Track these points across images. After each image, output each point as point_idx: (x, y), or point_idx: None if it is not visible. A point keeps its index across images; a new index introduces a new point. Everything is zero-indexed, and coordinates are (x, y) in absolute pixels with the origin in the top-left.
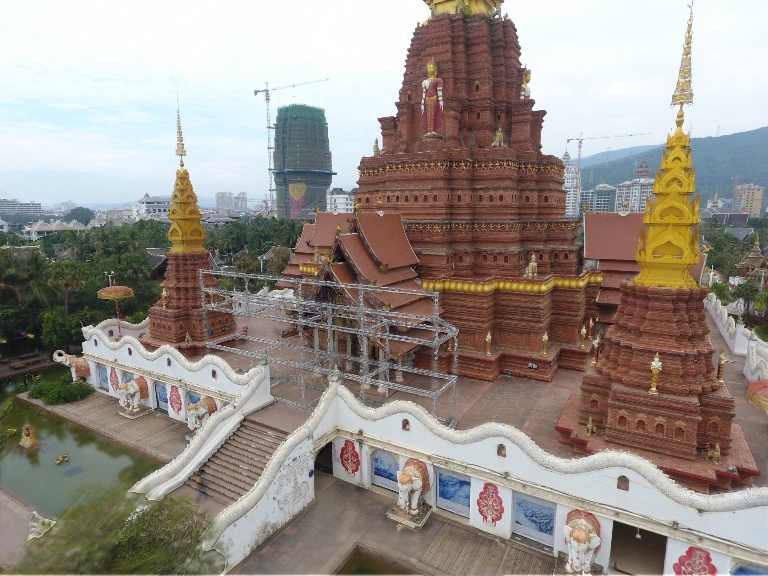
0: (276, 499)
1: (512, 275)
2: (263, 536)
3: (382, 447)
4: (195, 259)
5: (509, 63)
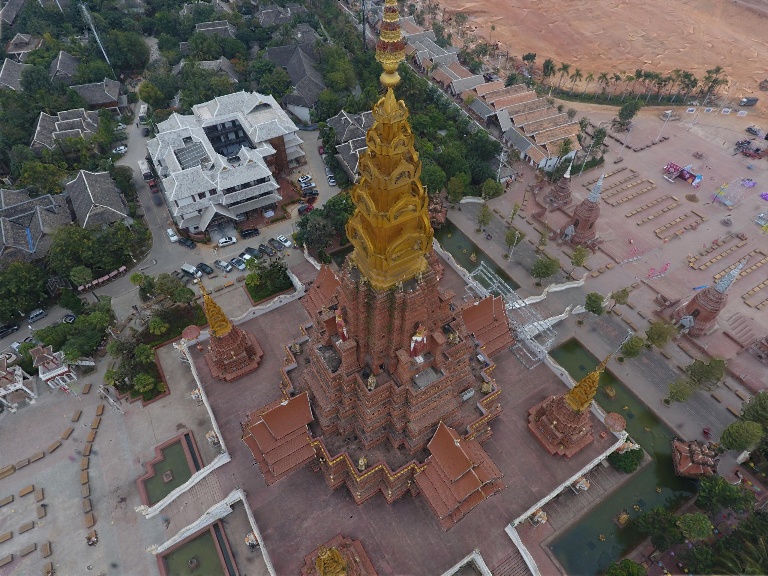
0: None
1: None
2: None
3: None
4: None
5: None
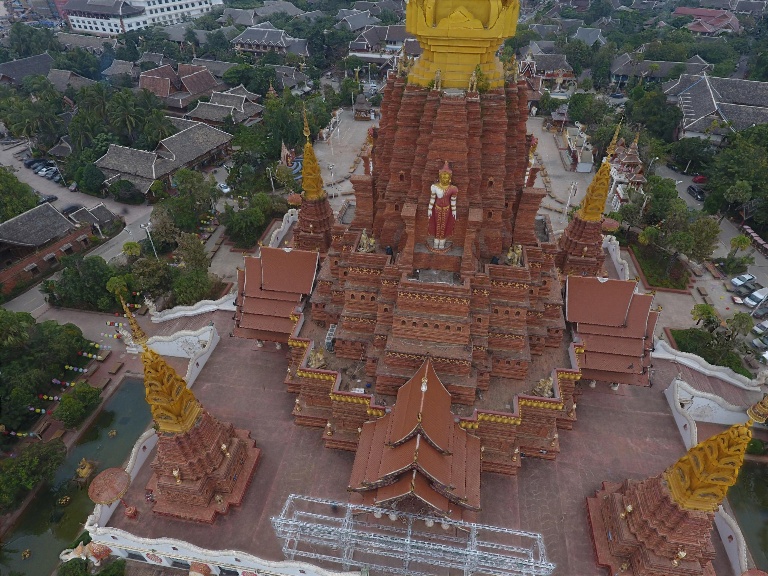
0: None
1: (523, 375)
2: None
3: None
4: (197, 429)
5: (520, 138)
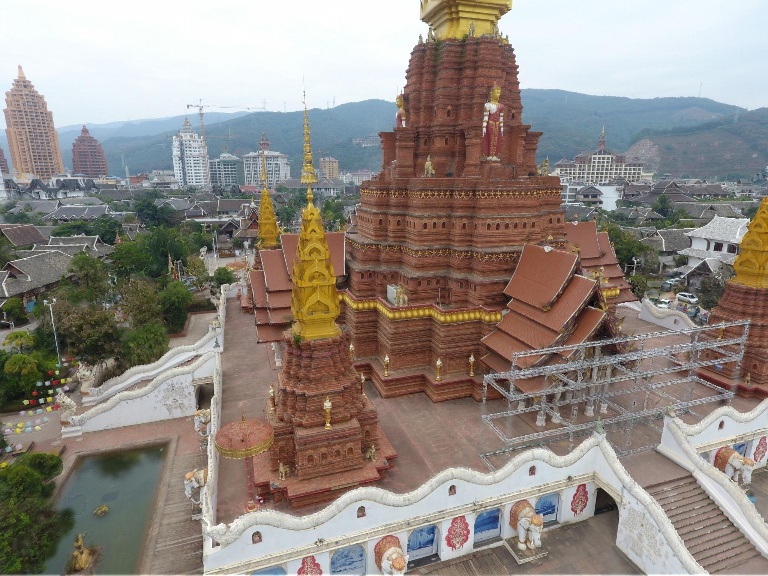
0: None
1: None
2: None
3: (703, 451)
4: None
5: None
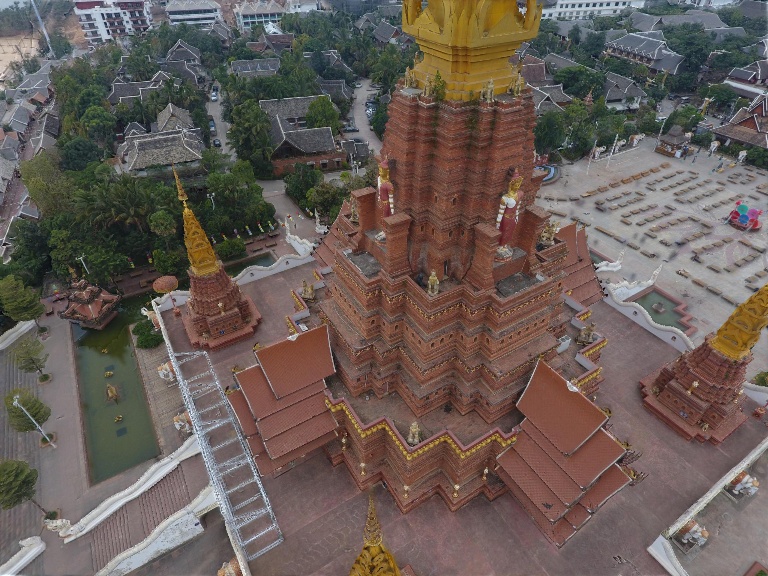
0: (164, 541)
1: None
2: (157, 555)
3: None
4: (206, 280)
5: (490, 167)
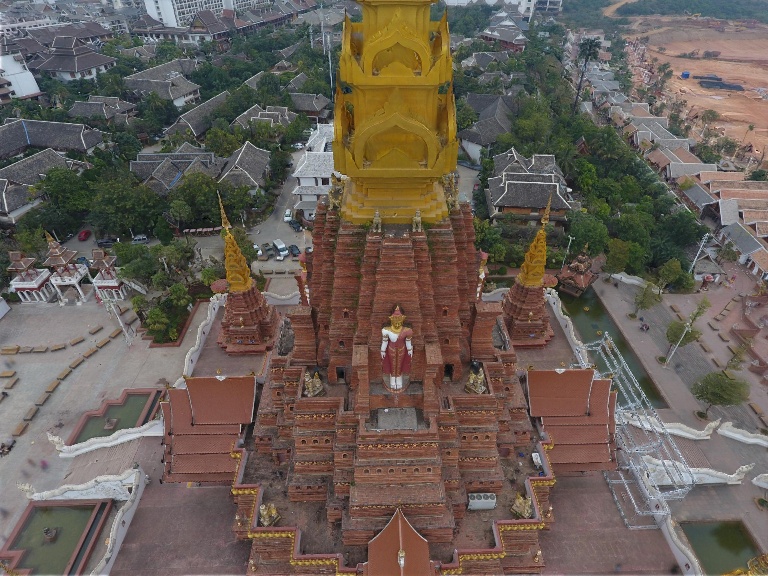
0: None
1: None
2: None
3: None
4: None
5: None
